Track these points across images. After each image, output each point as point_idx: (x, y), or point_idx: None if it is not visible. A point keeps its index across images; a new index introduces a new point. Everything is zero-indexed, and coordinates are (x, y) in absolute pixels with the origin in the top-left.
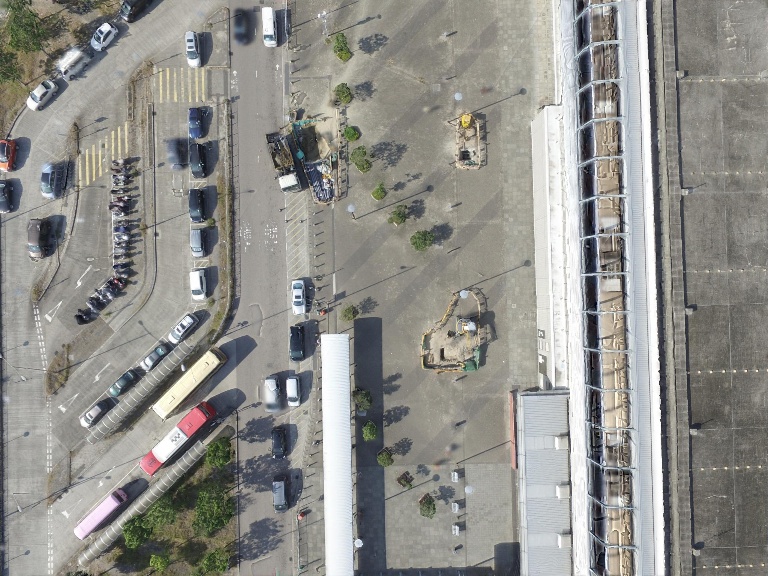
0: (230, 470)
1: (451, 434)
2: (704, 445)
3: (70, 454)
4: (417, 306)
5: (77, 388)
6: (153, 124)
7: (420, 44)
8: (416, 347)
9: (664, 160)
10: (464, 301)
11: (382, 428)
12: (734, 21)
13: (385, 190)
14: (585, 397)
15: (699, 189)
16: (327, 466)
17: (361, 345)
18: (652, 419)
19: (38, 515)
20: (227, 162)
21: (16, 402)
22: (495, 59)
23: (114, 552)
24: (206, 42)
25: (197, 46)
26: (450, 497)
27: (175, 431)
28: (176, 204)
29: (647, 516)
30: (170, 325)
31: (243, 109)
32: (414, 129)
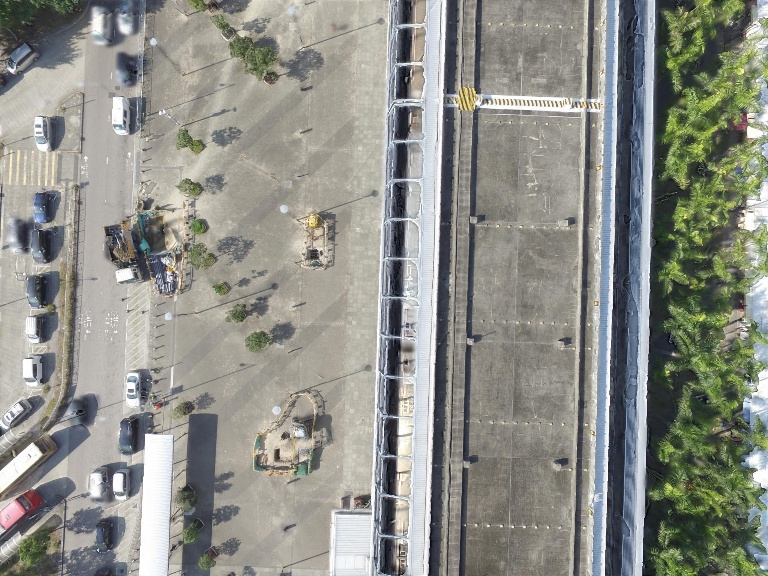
0: (54, 560)
1: (280, 537)
2: None
3: None
4: (254, 405)
5: None
6: (0, 206)
7: (274, 139)
8: (250, 446)
9: (452, 307)
10: (302, 403)
11: (211, 526)
12: (536, 167)
13: (229, 285)
14: (373, 534)
15: (488, 337)
16: (143, 567)
17: (195, 441)
18: (423, 571)
19: None
20: (71, 248)
21: None
22: (349, 159)
23: None
24: (58, 126)
25: (46, 131)
26: None
27: None
28: (18, 287)
29: None
30: (4, 409)
31: (92, 195)
32: (262, 225)
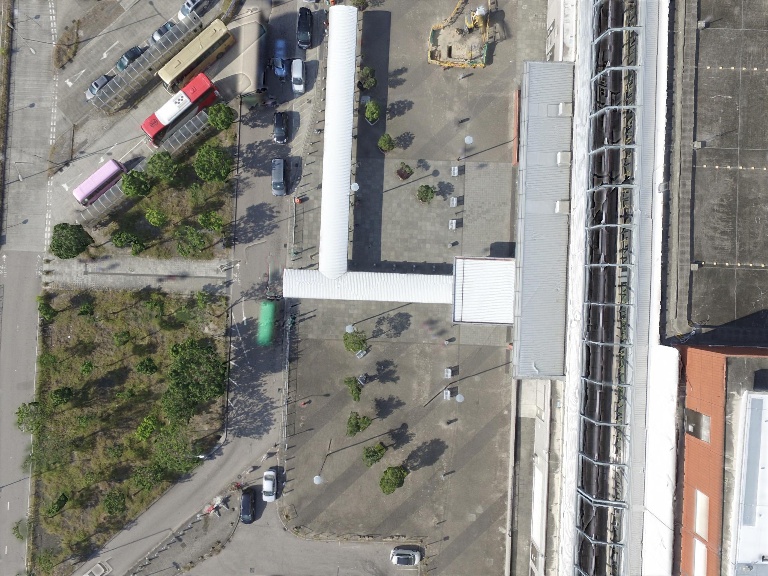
0: (231, 153)
1: (454, 131)
2: (712, 44)
3: (74, 127)
4: (427, 2)
5: (85, 64)
6: None
7: None
8: (424, 43)
9: None
10: None
11: (385, 121)
12: None
13: None
14: (593, 18)
15: None
16: (328, 138)
17: (369, 38)
18: (660, 12)
19: (38, 185)
20: None
21: (24, 73)
22: None
23: (111, 226)
24: None
25: None
26: (449, 193)
27: (179, 94)
28: None
29: (649, 112)
30: (180, 7)
31: None
32: None
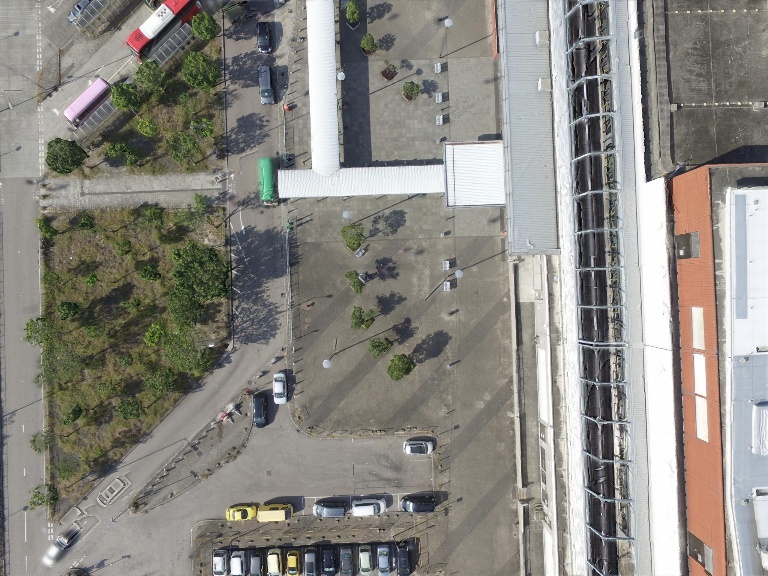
0: (217, 66)
1: (434, 30)
2: None
3: (59, 52)
4: None
5: None
6: None
7: None
8: None
9: None
10: None
11: (366, 25)
12: None
13: None
14: None
15: None
16: (311, 40)
17: None
18: None
19: (29, 112)
20: None
21: (6, 2)
22: None
23: (104, 146)
24: None
25: None
26: (434, 91)
27: (161, 7)
28: None
29: None
30: None
31: None
32: None
